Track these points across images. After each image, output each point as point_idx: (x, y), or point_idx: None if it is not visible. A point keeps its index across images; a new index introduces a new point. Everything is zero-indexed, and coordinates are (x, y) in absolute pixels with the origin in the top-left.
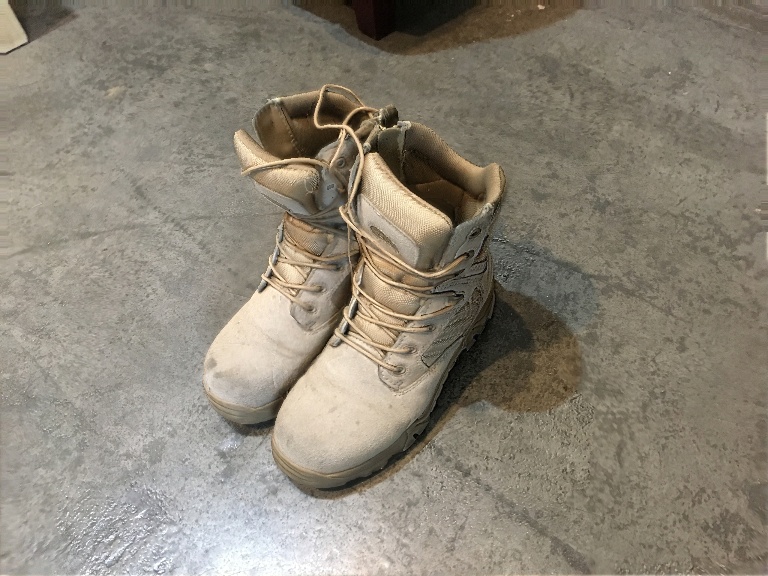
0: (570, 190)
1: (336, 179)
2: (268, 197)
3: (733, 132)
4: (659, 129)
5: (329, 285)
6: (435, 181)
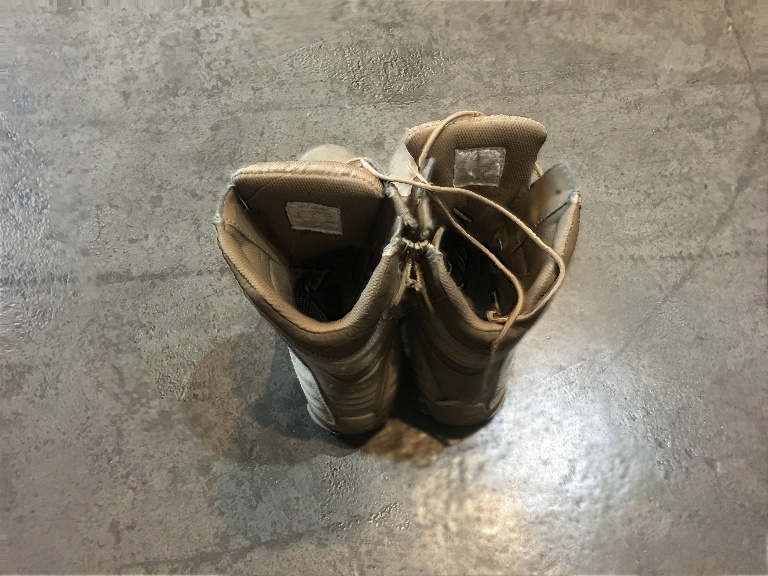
0: None
1: None
2: None
3: None
4: None
5: None
6: None
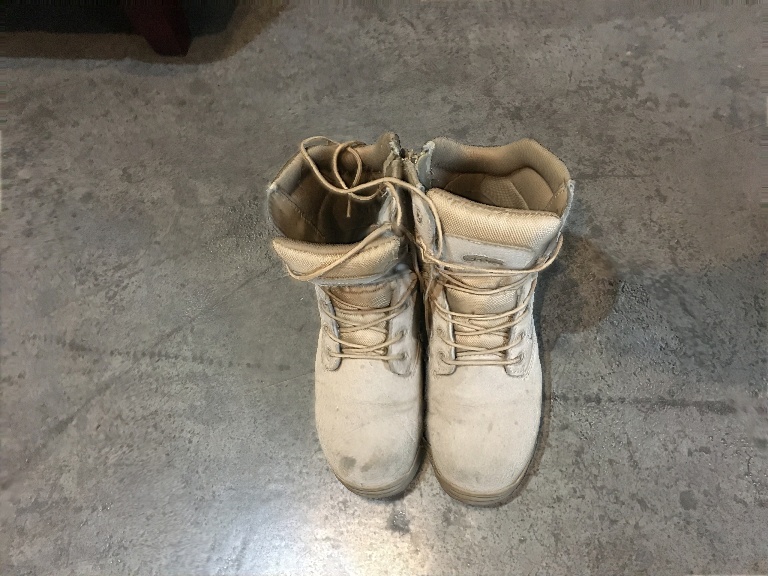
0: (480, 114)
1: (398, 231)
2: (333, 284)
3: None
4: (505, 20)
5: (407, 325)
6: (454, 179)
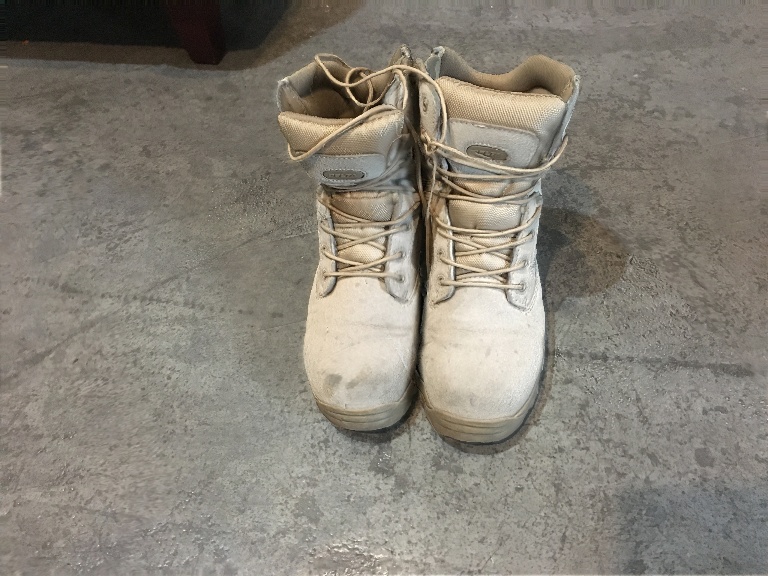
0: None
1: (404, 123)
2: (335, 172)
3: (573, 31)
4: (519, 48)
5: (406, 247)
6: None
